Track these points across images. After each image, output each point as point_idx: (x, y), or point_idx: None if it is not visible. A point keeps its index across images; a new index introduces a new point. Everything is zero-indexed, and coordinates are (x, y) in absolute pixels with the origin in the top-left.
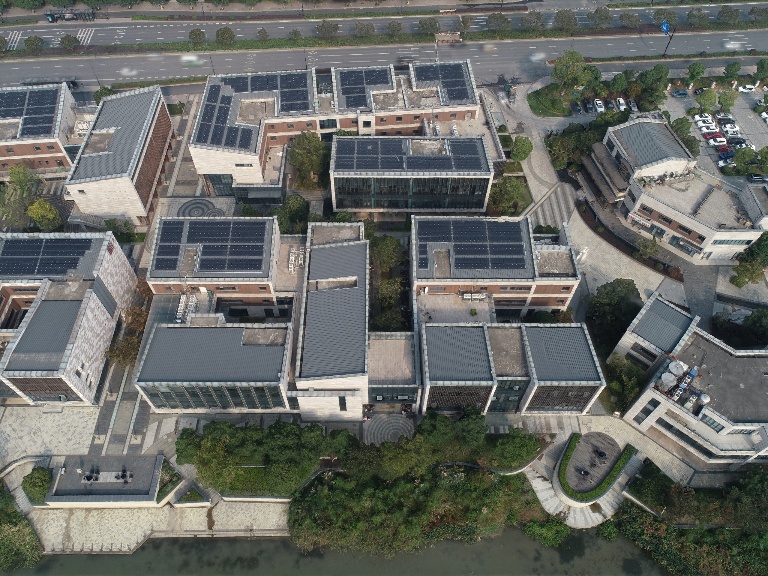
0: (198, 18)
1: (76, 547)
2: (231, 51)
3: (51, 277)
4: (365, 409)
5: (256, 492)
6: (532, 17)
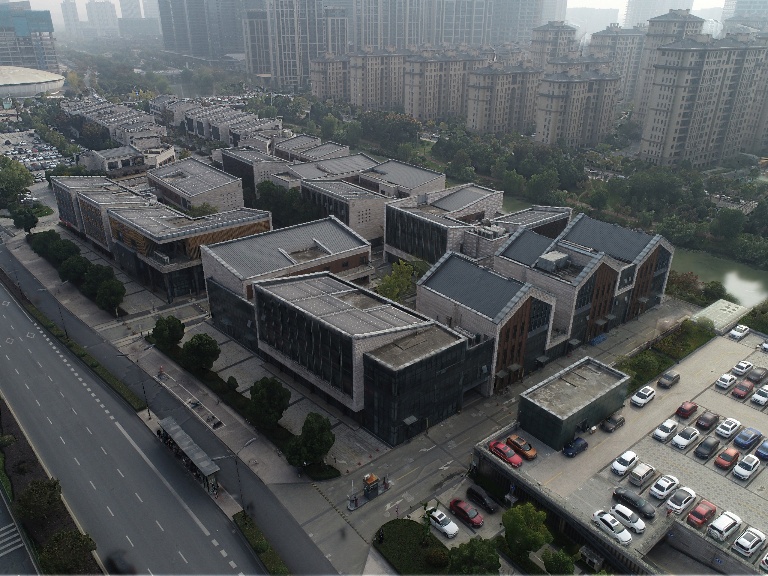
0: None
1: None
2: None
3: None
4: None
5: None
6: None
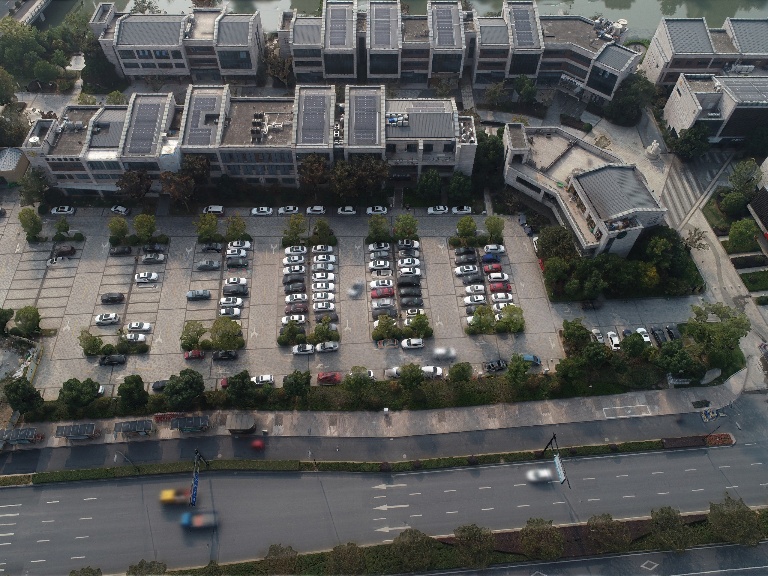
0: None
1: None
2: None
3: None
4: None
5: None
6: None
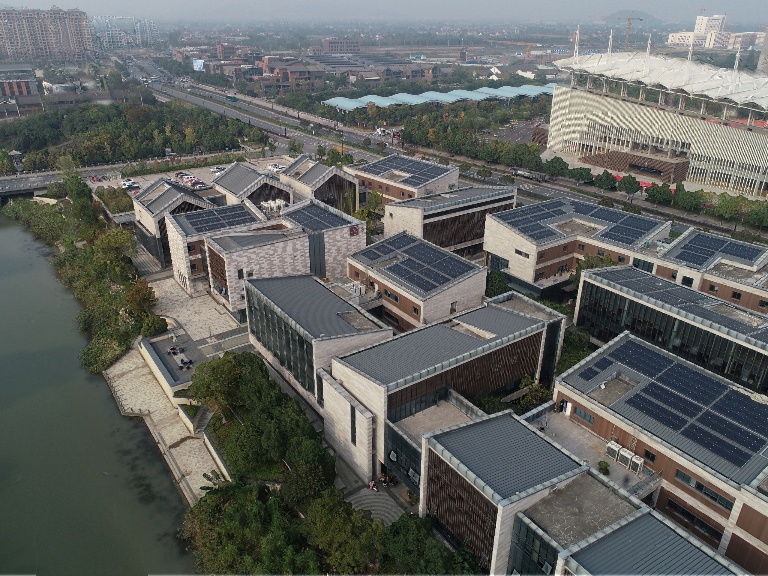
0: (624, 203)
1: (115, 383)
2: None
3: (306, 229)
4: (383, 477)
5: (221, 448)
6: None
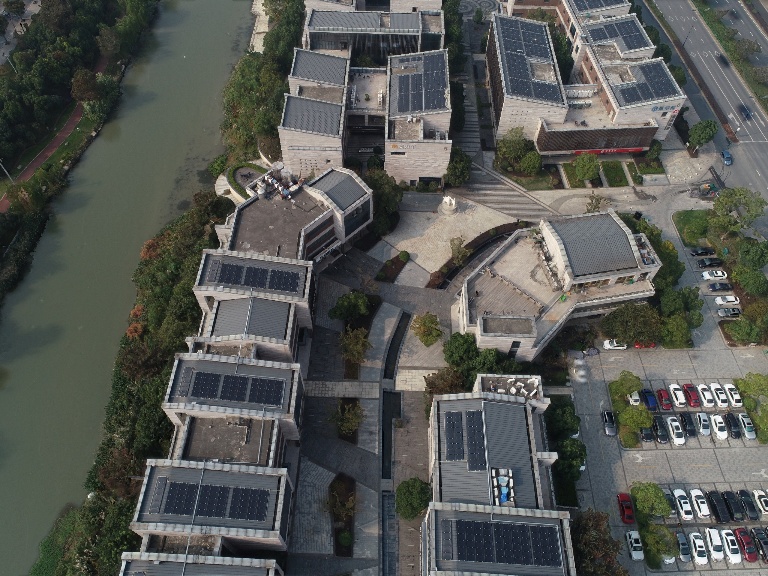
0: None
1: None
2: (694, 7)
3: None
4: None
5: None
6: None
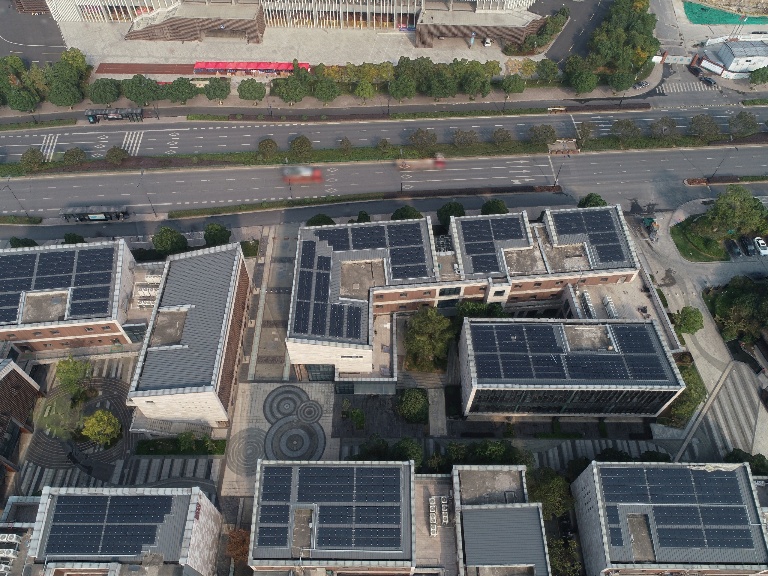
0: (265, 118)
1: None
2: (307, 164)
3: (120, 557)
4: None
5: None
6: (664, 124)
